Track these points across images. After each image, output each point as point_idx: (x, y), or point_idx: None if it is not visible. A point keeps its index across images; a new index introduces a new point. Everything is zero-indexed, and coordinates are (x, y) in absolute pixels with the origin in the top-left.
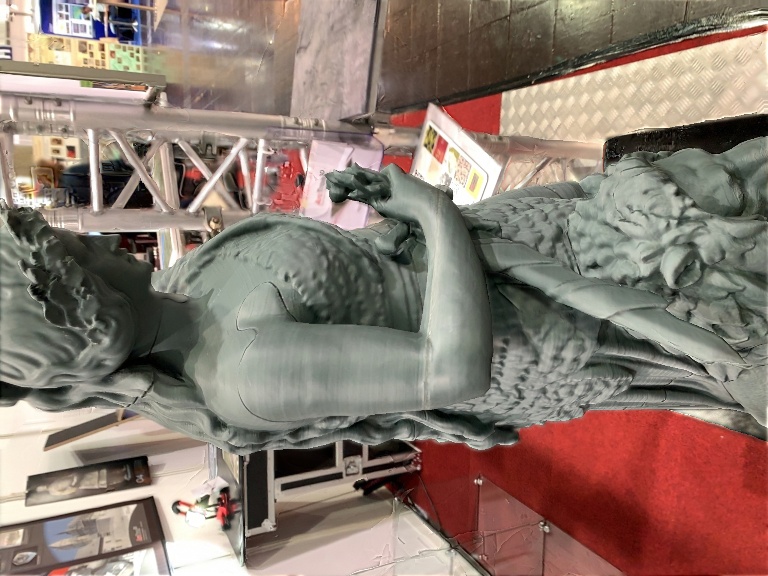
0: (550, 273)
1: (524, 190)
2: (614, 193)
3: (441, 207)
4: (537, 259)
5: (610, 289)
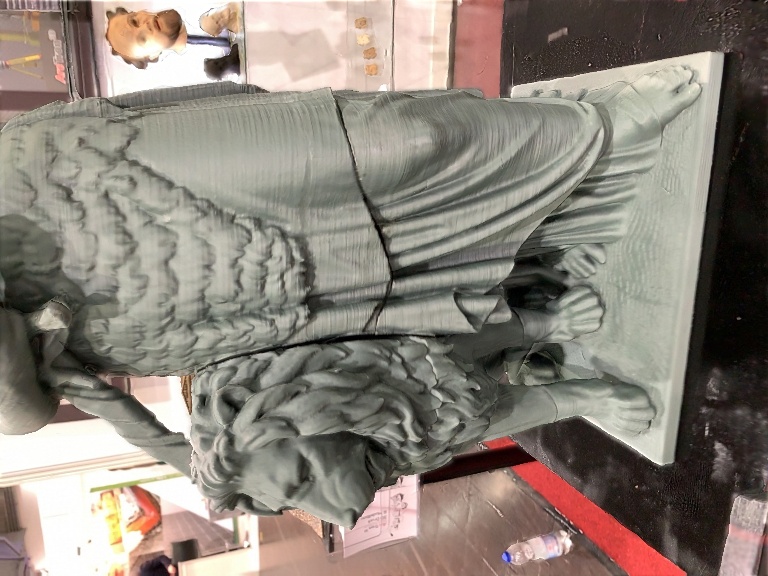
0: (119, 426)
1: (302, 178)
2: (194, 458)
3: (1, 410)
4: (114, 418)
5: (159, 450)
